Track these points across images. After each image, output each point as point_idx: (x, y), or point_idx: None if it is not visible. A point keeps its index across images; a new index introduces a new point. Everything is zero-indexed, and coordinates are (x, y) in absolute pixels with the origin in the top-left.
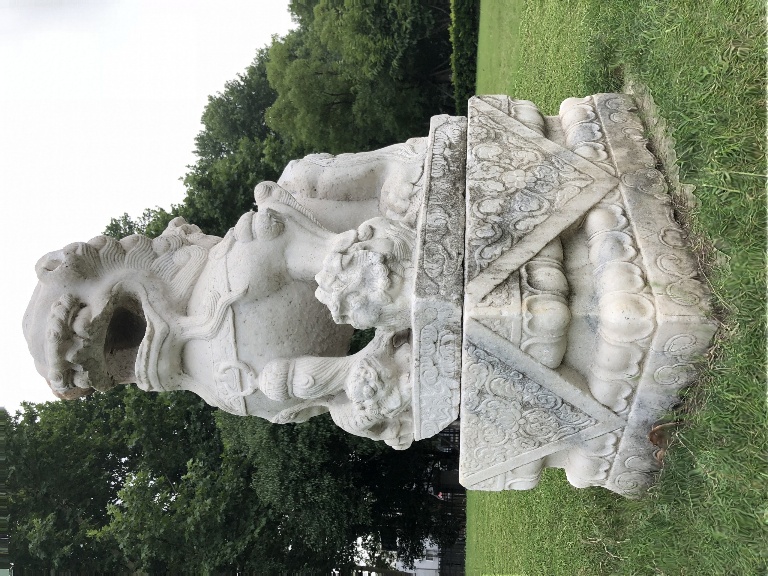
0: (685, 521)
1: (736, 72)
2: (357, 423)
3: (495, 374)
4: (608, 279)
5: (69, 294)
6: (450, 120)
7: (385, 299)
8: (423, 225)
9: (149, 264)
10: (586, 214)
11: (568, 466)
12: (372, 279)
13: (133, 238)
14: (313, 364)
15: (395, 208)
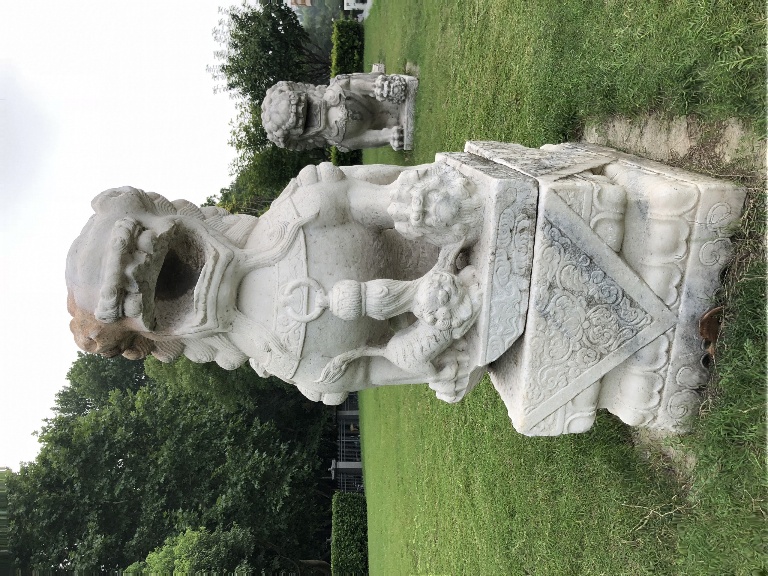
0: None
1: (723, 0)
2: (423, 348)
3: (566, 260)
4: (646, 180)
5: (132, 217)
6: None
7: (464, 193)
8: None
9: None
10: (603, 167)
11: (620, 400)
12: (449, 181)
13: None
14: (384, 280)
15: None
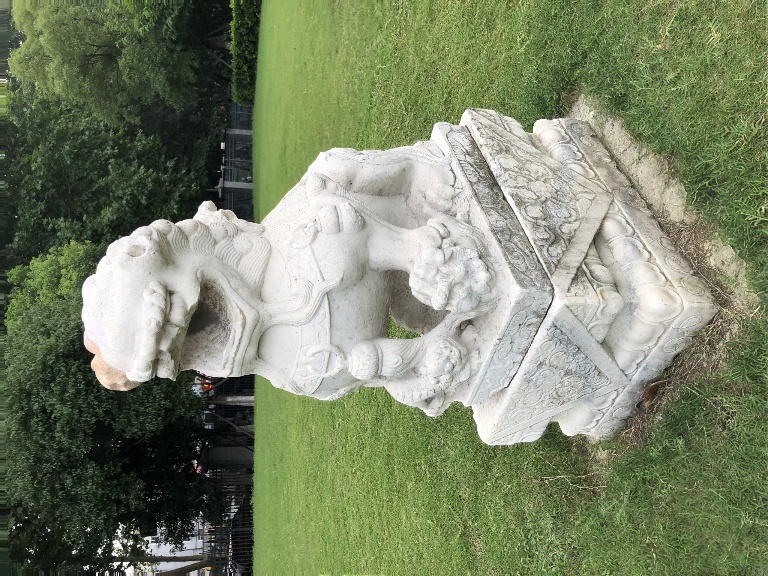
0: (699, 448)
1: (764, 137)
2: (421, 395)
3: (559, 349)
4: (641, 275)
5: (158, 281)
6: (454, 128)
7: (486, 289)
8: (490, 225)
9: (212, 250)
10: (602, 222)
11: (565, 419)
12: (473, 272)
13: (193, 223)
14: (398, 345)
15: (438, 206)
